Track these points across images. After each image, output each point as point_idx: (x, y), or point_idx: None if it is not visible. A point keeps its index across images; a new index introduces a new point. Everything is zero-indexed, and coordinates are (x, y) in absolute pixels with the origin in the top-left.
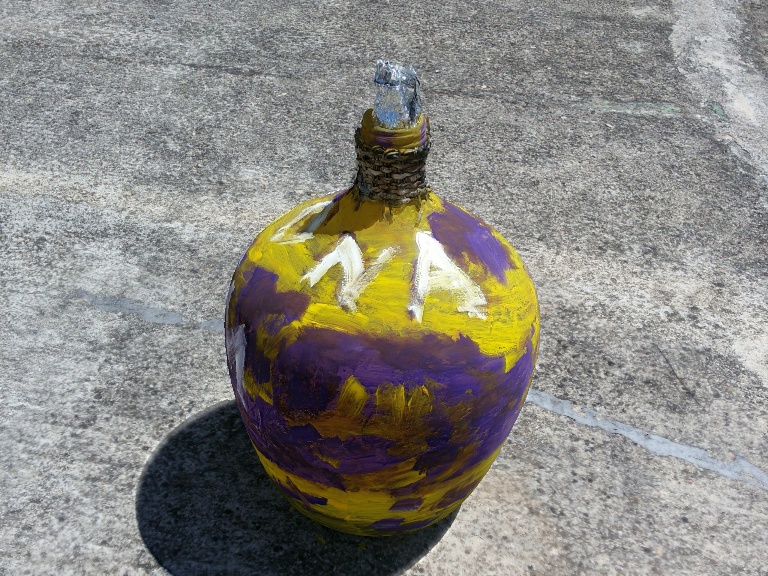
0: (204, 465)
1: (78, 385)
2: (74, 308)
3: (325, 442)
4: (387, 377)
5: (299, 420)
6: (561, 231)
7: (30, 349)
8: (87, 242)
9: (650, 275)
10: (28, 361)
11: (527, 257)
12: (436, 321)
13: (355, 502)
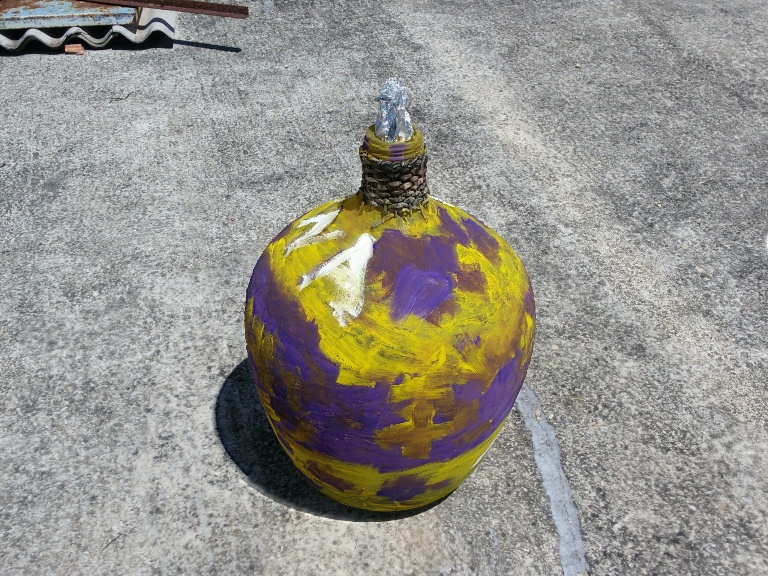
0: None
1: None
2: None
3: None
4: None
5: None
6: None
7: None
8: (498, 205)
9: None
10: None
11: None
12: (308, 297)
13: None
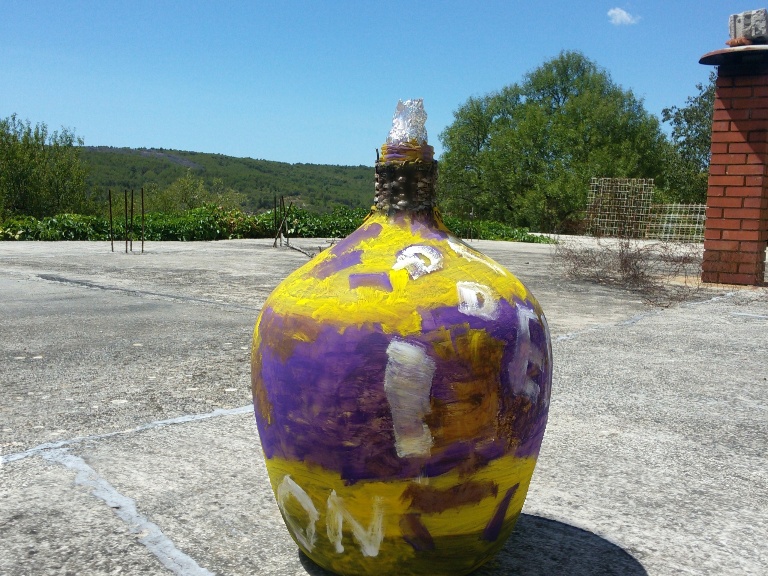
0: None
1: None
2: None
3: None
4: None
5: None
6: None
7: None
8: None
9: None
10: None
11: None
12: None
13: None
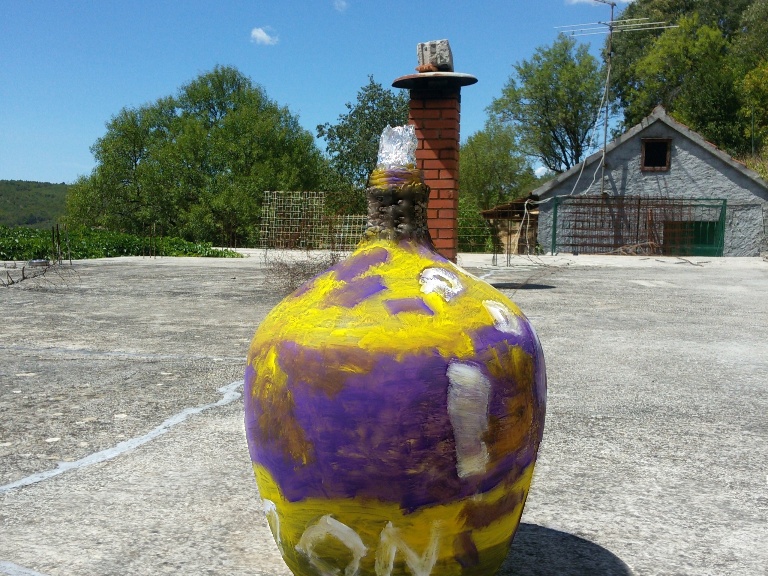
0: None
1: None
2: None
3: None
4: None
5: None
6: None
7: None
8: None
9: None
10: None
11: None
12: None
13: None
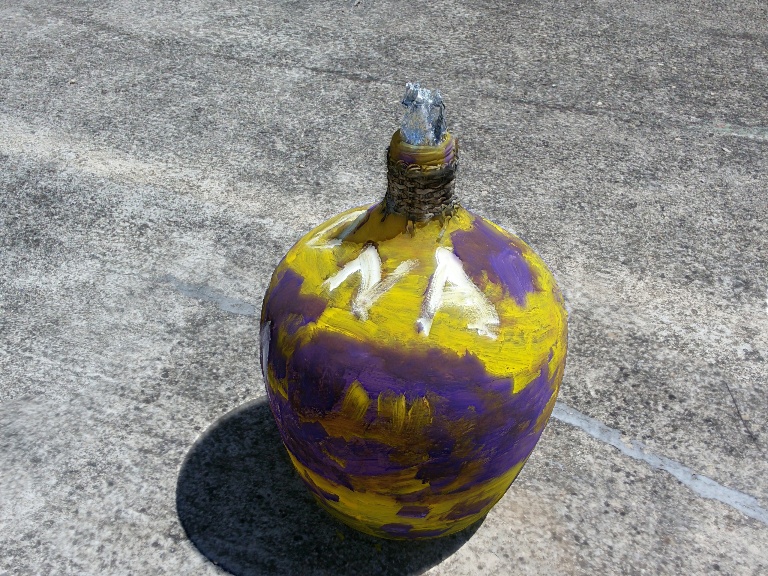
0: (247, 450)
1: (150, 363)
2: (161, 291)
3: (332, 441)
4: (389, 385)
5: (309, 417)
6: (649, 256)
7: (115, 325)
8: (184, 231)
9: (736, 310)
10: (111, 336)
11: (607, 280)
12: (443, 335)
13: (363, 502)
